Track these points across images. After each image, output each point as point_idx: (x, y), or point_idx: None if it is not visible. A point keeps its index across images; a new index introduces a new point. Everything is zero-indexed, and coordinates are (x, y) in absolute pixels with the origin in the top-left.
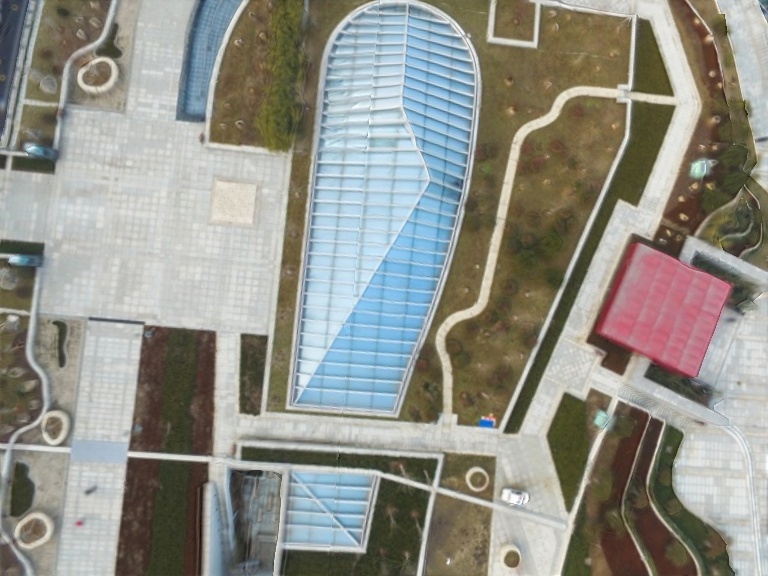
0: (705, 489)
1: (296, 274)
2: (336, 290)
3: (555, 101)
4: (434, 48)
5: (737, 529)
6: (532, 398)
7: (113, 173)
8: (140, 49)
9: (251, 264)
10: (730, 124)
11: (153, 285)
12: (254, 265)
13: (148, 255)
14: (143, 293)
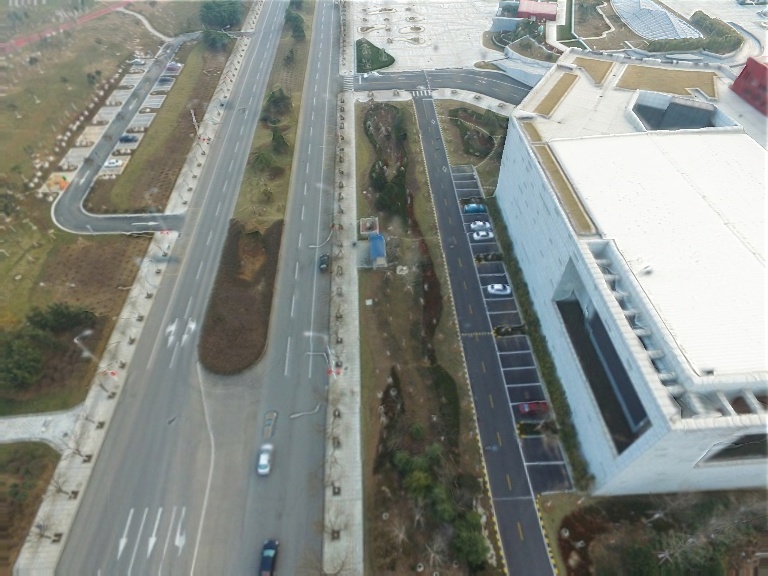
0: (491, 4)
1: (662, 5)
2: (648, 1)
3: (606, 35)
4: (664, 34)
5: (477, 0)
6: (567, 0)
7: (738, 14)
8: (763, 30)
9: (677, 7)
10: (536, 34)
11: (701, 3)
12: (676, 7)
13: (709, 6)
14: (702, 2)
